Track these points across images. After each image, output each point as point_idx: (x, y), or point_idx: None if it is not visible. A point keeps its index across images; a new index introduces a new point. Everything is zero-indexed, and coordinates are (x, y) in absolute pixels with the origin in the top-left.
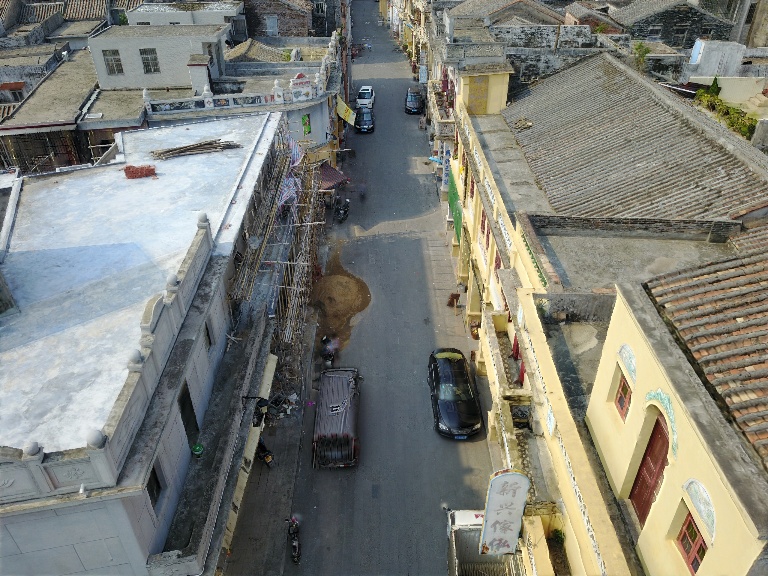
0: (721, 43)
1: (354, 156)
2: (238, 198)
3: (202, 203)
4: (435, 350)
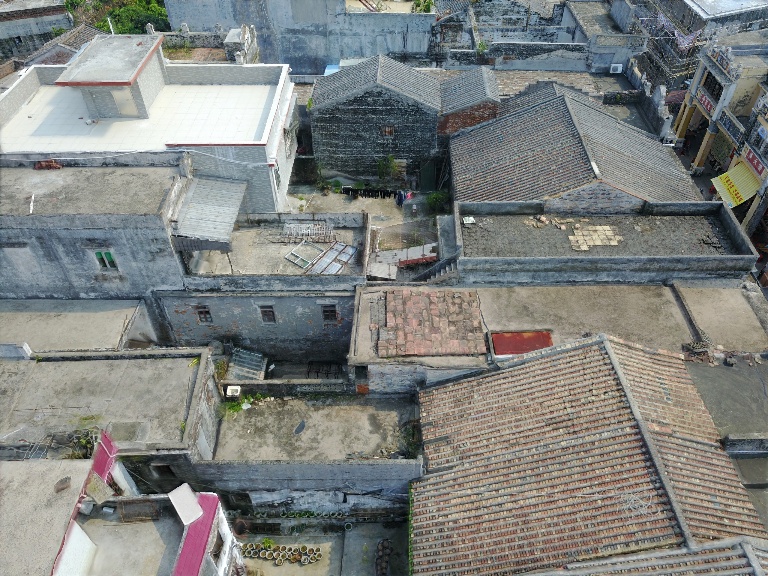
0: (362, 59)
1: None
2: None
3: None
4: None
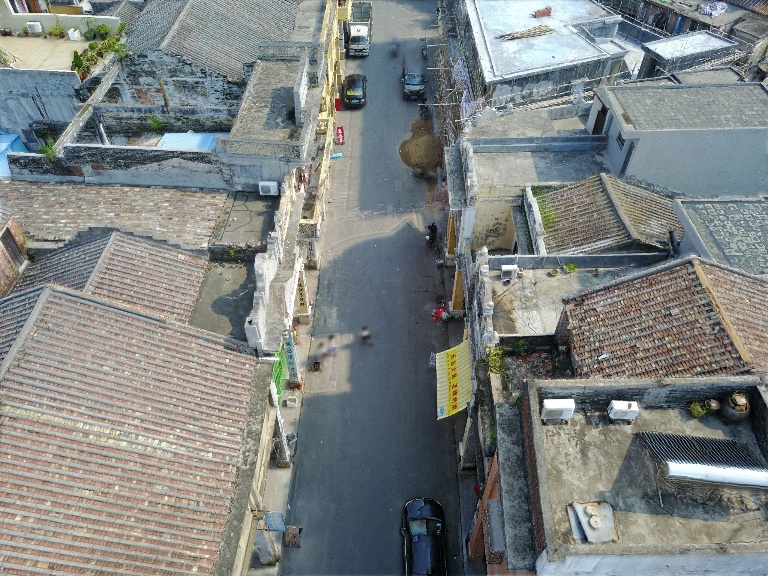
0: None
1: (432, 361)
2: (472, 4)
3: (490, 0)
4: (361, 97)
